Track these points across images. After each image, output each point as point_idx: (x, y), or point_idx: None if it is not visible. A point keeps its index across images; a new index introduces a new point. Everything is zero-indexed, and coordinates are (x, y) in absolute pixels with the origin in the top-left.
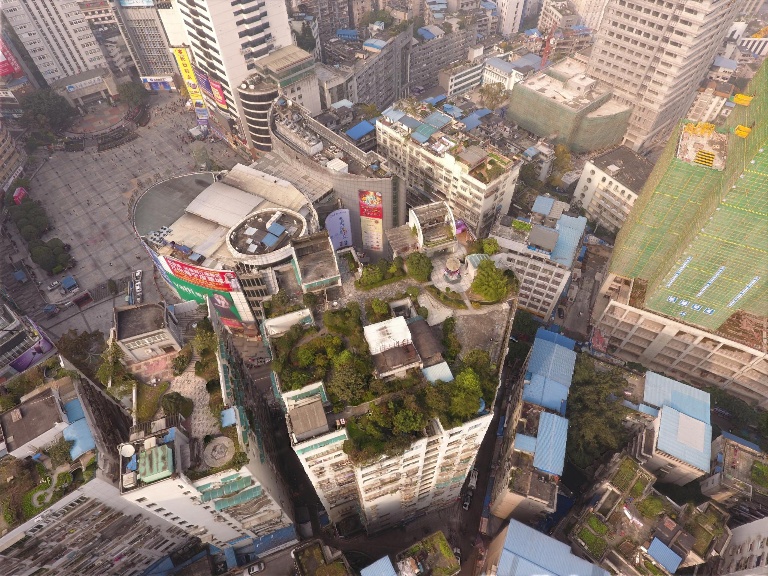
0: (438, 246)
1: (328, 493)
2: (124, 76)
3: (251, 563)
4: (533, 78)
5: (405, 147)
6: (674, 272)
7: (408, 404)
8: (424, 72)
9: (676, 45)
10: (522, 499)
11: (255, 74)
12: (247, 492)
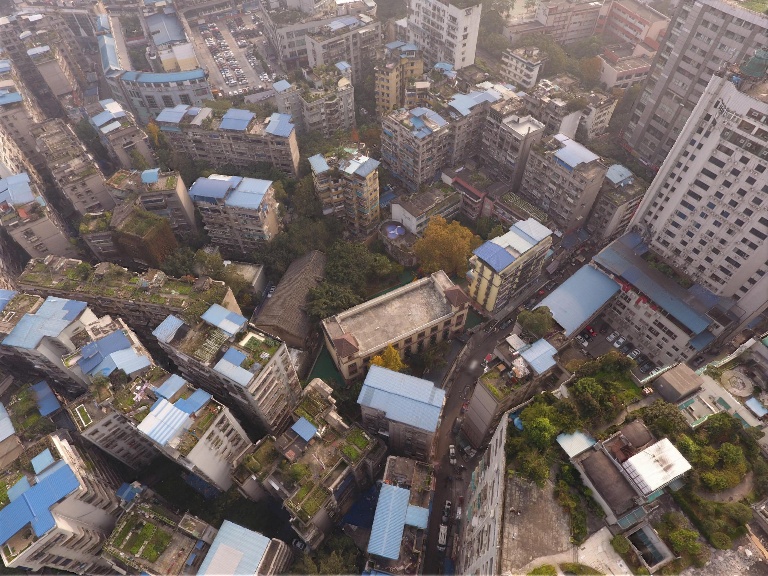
0: None
1: None
2: None
3: None
4: None
5: None
6: None
7: None
8: None
9: None
10: None
11: None
12: None
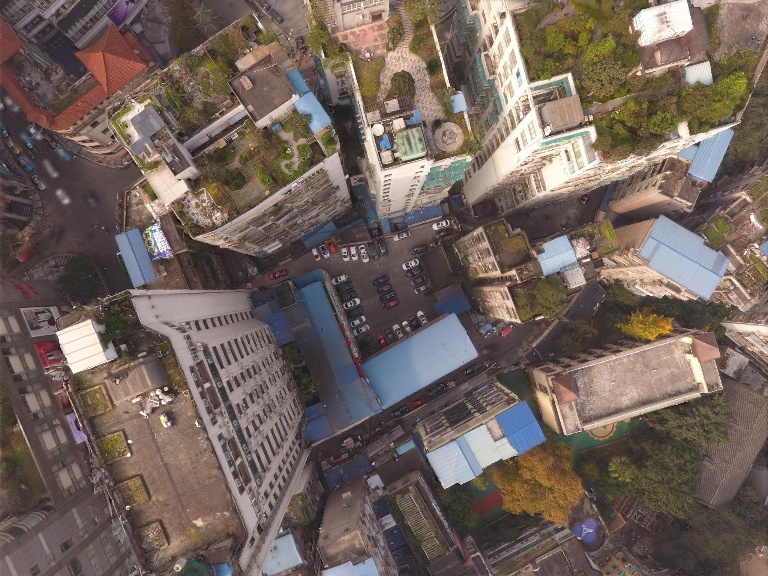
0: None
1: None
2: None
3: (400, 231)
4: None
5: None
6: None
7: (667, 106)
8: None
9: None
10: (665, 199)
11: None
12: None
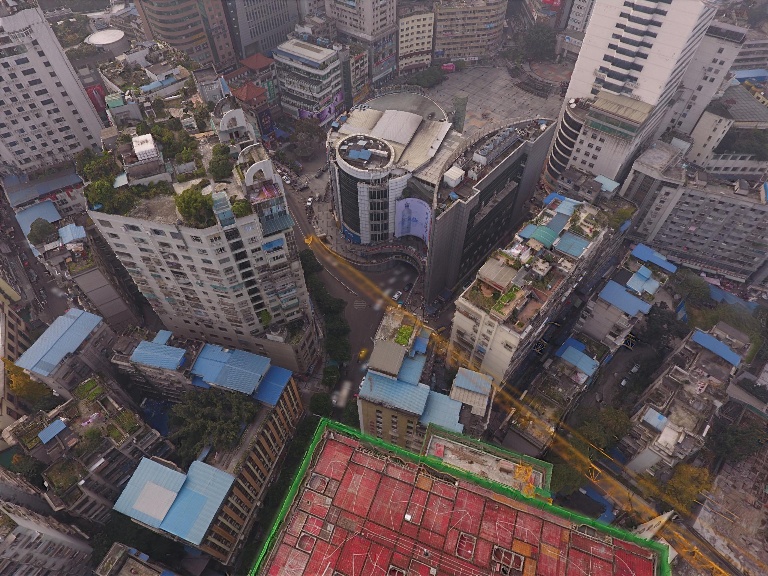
0: None
1: None
2: None
3: None
4: None
5: None
6: None
7: None
8: None
9: None
10: None
11: None
12: None
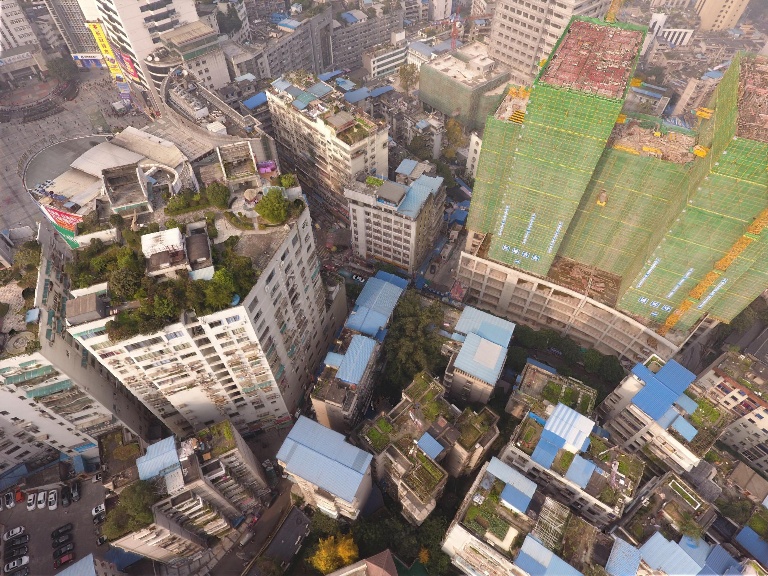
0: (240, 179)
1: (145, 395)
2: (54, 53)
3: (99, 470)
4: (440, 59)
5: (289, 114)
6: (500, 221)
7: (167, 295)
8: (350, 55)
9: (556, 27)
10: (324, 405)
11: (162, 48)
12: (57, 384)
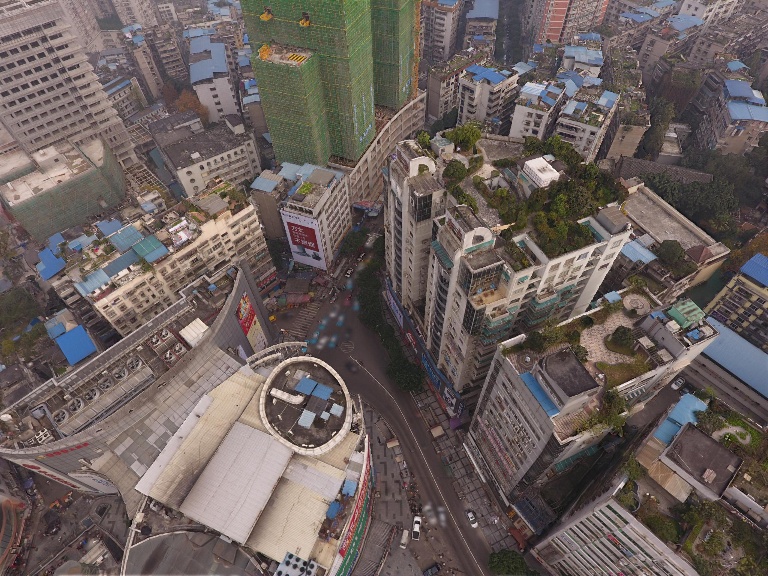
0: None
1: None
2: None
3: None
4: (5, 195)
5: (154, 279)
6: (355, 122)
7: None
8: None
9: (74, 68)
10: None
11: None
12: None
